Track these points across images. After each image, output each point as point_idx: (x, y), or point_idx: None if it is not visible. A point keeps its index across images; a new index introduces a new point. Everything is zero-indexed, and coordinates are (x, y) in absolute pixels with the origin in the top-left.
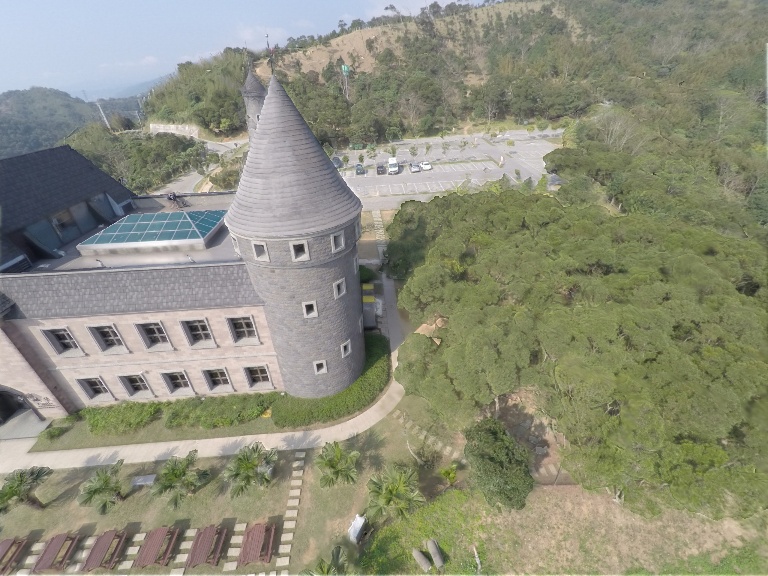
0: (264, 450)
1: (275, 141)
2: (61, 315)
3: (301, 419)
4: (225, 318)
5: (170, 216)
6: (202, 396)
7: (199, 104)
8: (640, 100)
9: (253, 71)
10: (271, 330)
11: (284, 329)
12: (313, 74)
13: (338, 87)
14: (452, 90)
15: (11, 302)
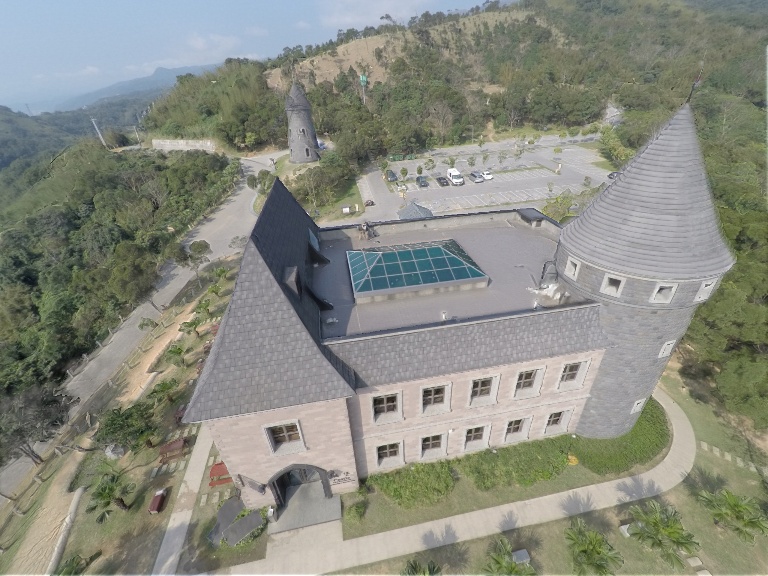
0: (660, 508)
1: (692, 174)
2: (406, 379)
3: (623, 464)
4: (564, 364)
5: (429, 252)
6: (492, 448)
7: (211, 117)
8: (654, 105)
9: (297, 83)
10: (601, 372)
11: (626, 371)
12: (328, 84)
13: (358, 97)
14: (473, 98)
15: (351, 369)
